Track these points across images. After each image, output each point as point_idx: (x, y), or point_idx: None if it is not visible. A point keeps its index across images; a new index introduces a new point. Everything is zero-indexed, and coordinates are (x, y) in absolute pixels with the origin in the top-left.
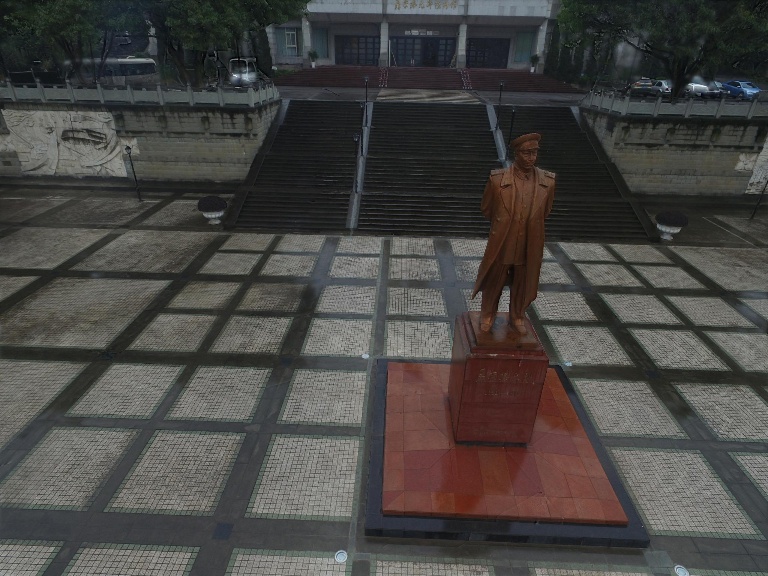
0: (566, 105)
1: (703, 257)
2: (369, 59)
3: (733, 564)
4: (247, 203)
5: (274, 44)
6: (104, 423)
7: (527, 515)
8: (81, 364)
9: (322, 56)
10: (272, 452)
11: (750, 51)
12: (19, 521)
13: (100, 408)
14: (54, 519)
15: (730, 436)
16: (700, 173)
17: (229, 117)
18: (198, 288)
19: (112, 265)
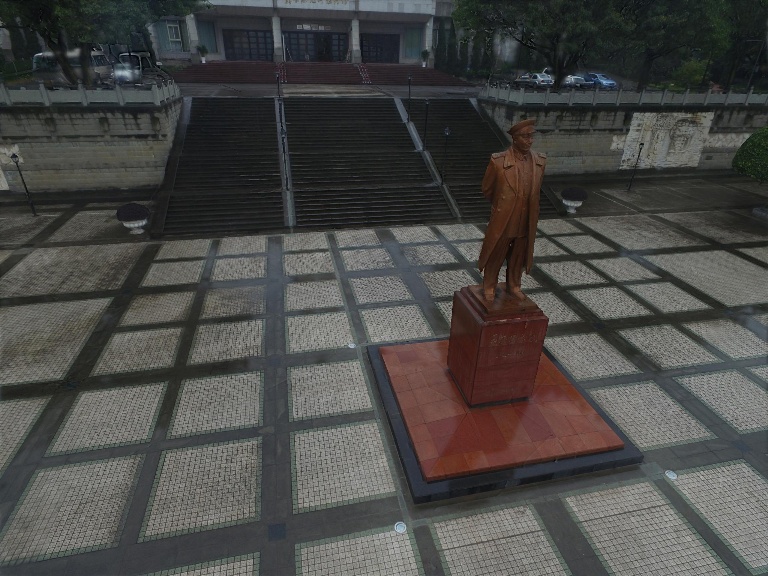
0: (465, 97)
1: (604, 225)
2: (262, 54)
3: (703, 461)
4: (171, 209)
5: (155, 38)
6: (97, 455)
7: (548, 456)
8: (40, 399)
9: (211, 51)
10: (296, 449)
11: (621, 47)
12: (39, 575)
13: (86, 441)
14: (82, 563)
15: (670, 365)
16: (585, 154)
17: (132, 117)
18: (147, 302)
19: (31, 289)
